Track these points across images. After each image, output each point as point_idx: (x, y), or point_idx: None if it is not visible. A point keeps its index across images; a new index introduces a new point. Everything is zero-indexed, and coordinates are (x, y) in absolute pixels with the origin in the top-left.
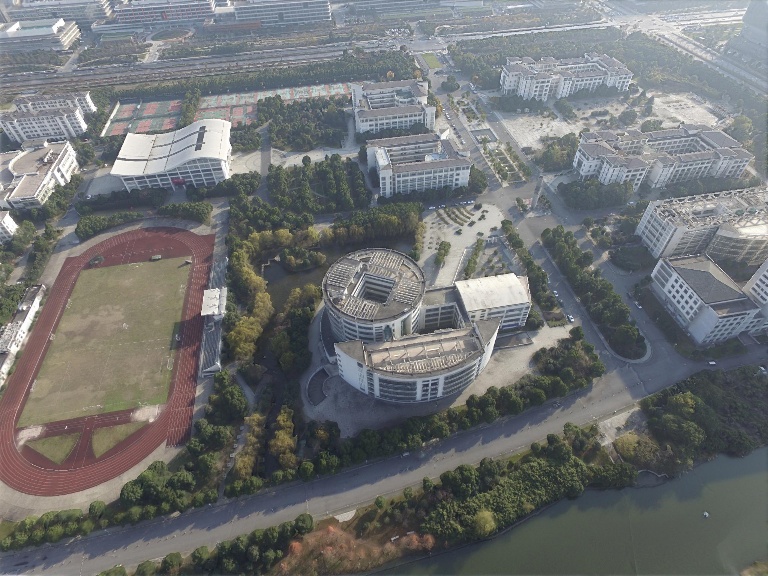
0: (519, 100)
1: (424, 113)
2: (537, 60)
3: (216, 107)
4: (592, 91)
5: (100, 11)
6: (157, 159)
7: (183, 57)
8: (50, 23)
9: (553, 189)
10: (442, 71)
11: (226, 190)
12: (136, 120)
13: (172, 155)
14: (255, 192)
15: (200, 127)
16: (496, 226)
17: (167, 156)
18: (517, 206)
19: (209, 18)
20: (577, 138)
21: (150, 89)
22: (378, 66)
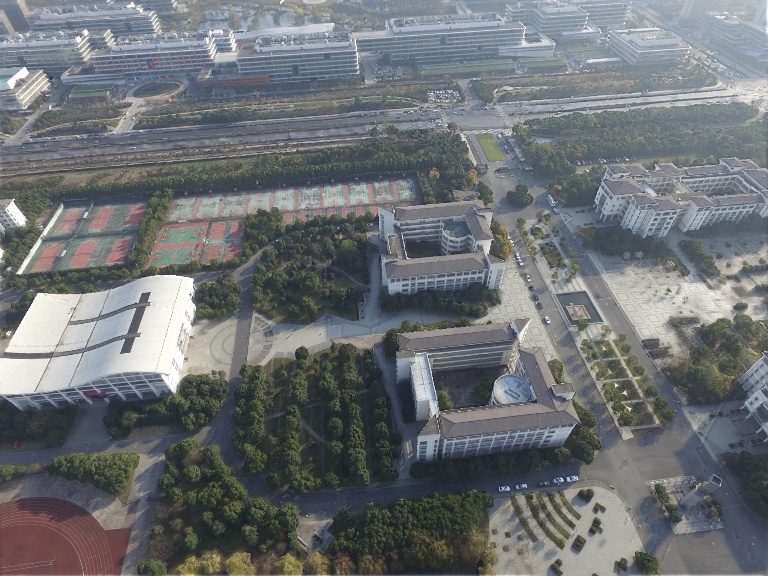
0: (627, 237)
1: (487, 269)
2: (640, 154)
3: (190, 220)
4: (735, 221)
5: (76, 55)
6: (66, 355)
7: (165, 126)
8: (11, 72)
9: (713, 453)
10: (506, 168)
11: (167, 418)
12: (77, 239)
13: (89, 350)
14: (214, 418)
15: (142, 294)
16: (625, 557)
17: (82, 350)
18: (655, 497)
19: (206, 68)
20: (739, 337)
21: (105, 187)
22: (417, 159)
